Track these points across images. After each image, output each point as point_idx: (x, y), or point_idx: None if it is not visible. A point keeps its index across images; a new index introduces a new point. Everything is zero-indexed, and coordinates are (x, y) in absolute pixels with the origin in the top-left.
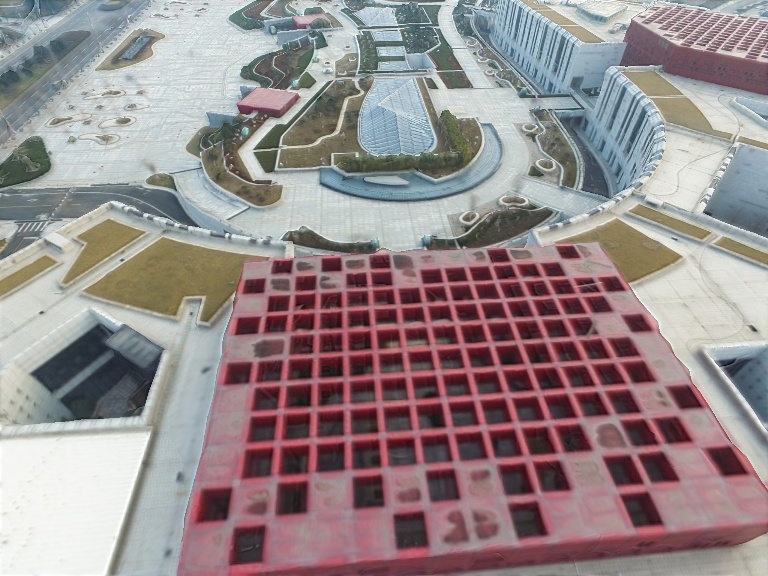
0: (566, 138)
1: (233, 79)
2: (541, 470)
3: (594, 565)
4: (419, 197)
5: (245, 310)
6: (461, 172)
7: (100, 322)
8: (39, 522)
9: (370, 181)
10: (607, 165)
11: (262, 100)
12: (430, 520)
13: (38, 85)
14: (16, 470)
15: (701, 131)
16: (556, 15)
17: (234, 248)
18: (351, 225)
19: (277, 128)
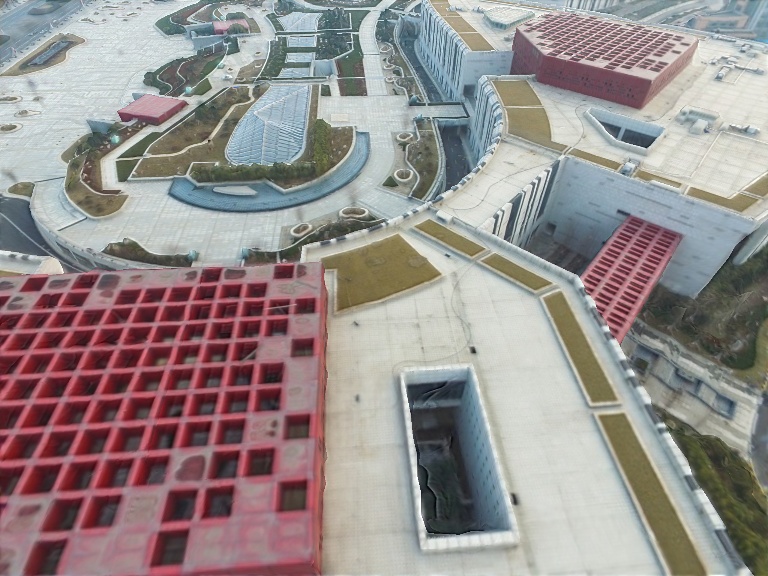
0: (438, 147)
1: (135, 85)
2: (92, 505)
3: None
4: (261, 208)
5: None
6: (314, 182)
7: None
8: None
9: (218, 191)
10: None
11: (144, 107)
12: None
13: None
14: None
15: (537, 143)
16: (461, 22)
17: None
18: (180, 237)
19: (150, 136)
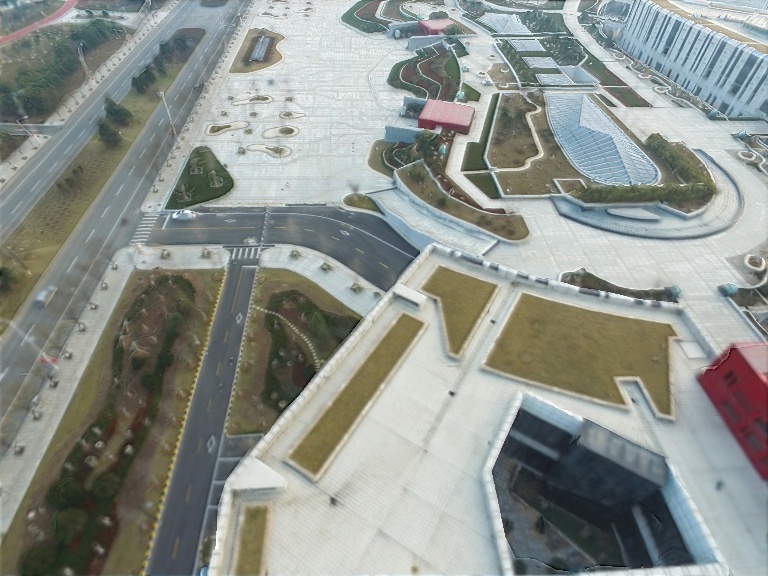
0: None
1: (381, 87)
2: None
3: None
4: (680, 235)
5: None
6: (708, 206)
7: (523, 407)
8: None
9: (616, 214)
10: None
11: (443, 114)
12: None
13: (176, 87)
14: None
15: None
16: (725, 31)
17: (615, 309)
18: (626, 267)
19: (473, 147)
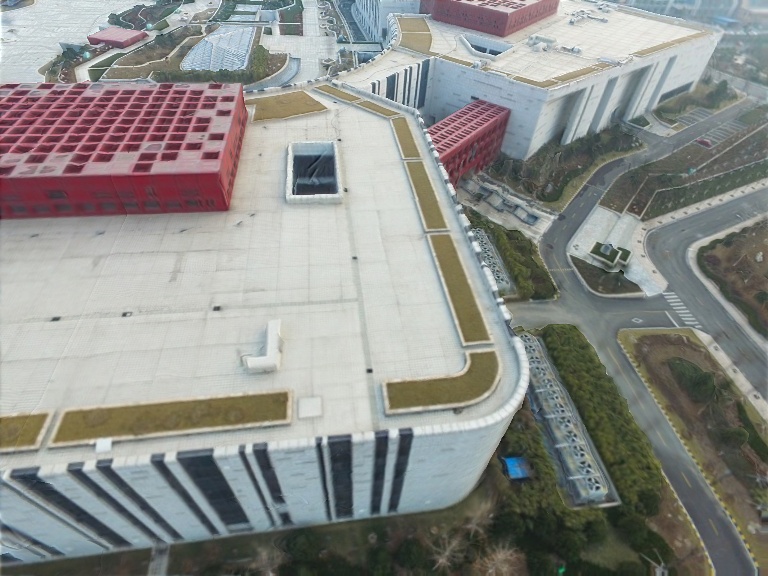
0: None
1: (101, 24)
2: (98, 155)
3: (138, 216)
4: None
5: None
6: (252, 85)
7: None
8: None
9: None
10: None
11: (110, 35)
12: (17, 168)
13: None
14: None
15: (418, 51)
16: None
17: None
18: None
19: (116, 55)
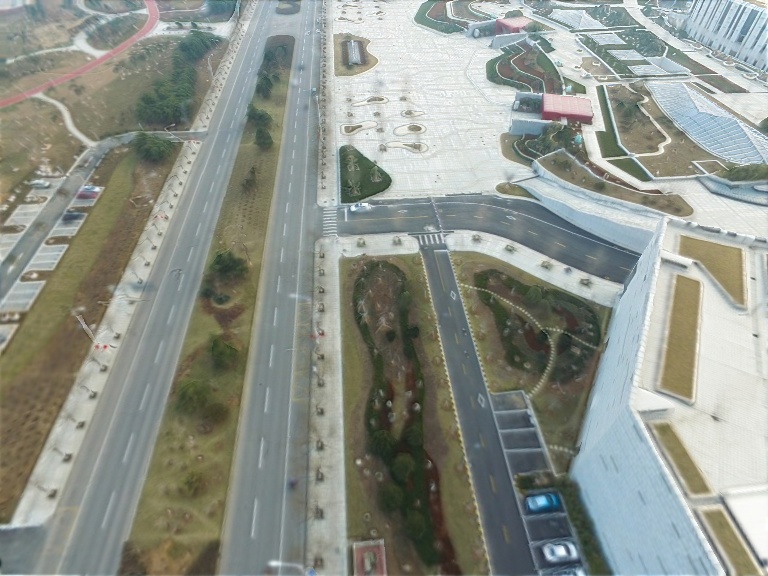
0: None
1: (483, 84)
2: None
3: None
4: None
5: None
6: None
7: None
8: None
9: (763, 190)
10: None
11: (564, 106)
12: None
13: (293, 92)
14: None
15: None
16: None
17: None
18: None
19: (603, 135)
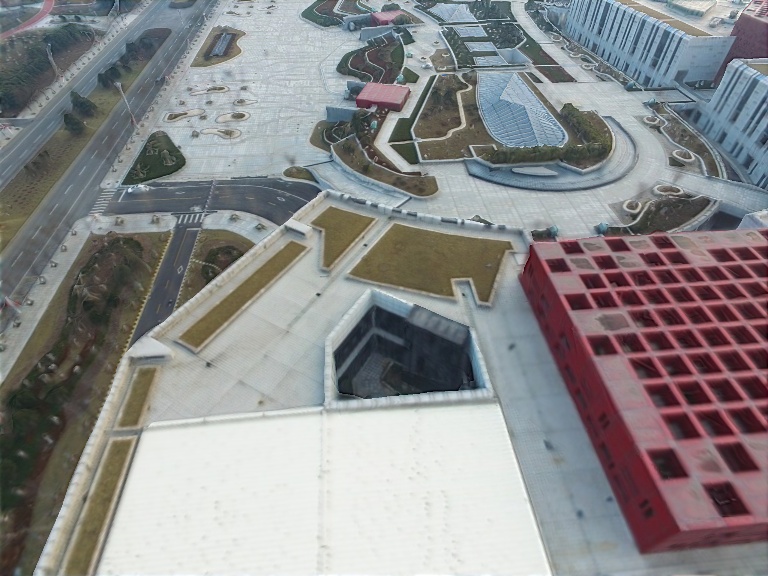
0: (690, 130)
1: (330, 75)
2: None
3: None
4: (573, 187)
5: (565, 287)
6: (604, 163)
7: (376, 303)
8: (447, 485)
9: (519, 172)
10: (731, 156)
11: (379, 94)
12: None
13: (140, 81)
14: (396, 438)
15: None
16: (648, 10)
17: (469, 233)
18: (518, 214)
19: (403, 121)
